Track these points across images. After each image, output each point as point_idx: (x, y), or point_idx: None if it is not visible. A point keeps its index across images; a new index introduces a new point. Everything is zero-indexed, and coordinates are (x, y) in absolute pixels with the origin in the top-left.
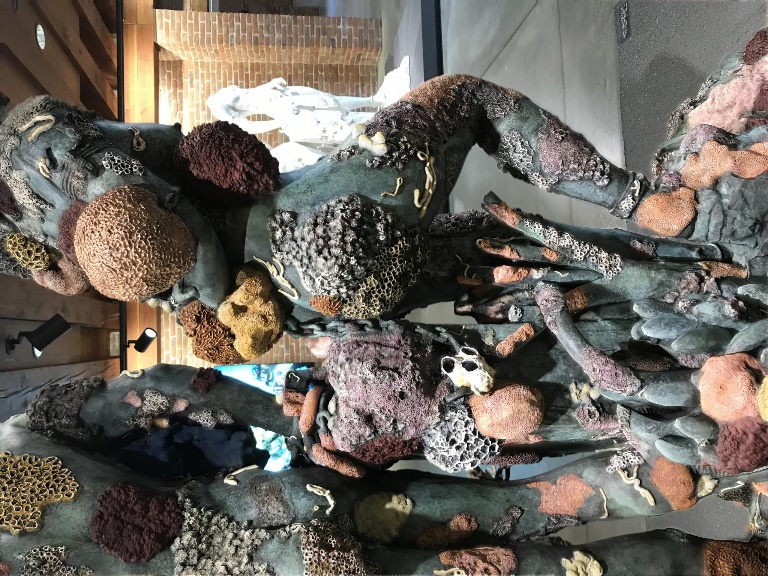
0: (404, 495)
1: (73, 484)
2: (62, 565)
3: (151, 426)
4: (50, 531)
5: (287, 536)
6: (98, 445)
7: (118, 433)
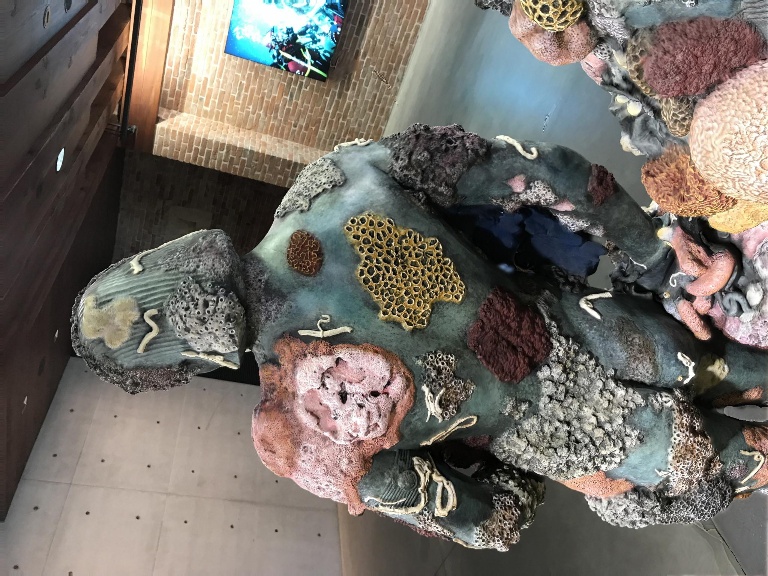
0: (724, 360)
1: (460, 284)
2: (454, 377)
3: (514, 211)
4: (434, 330)
5: (661, 409)
6: (454, 214)
7: (473, 204)
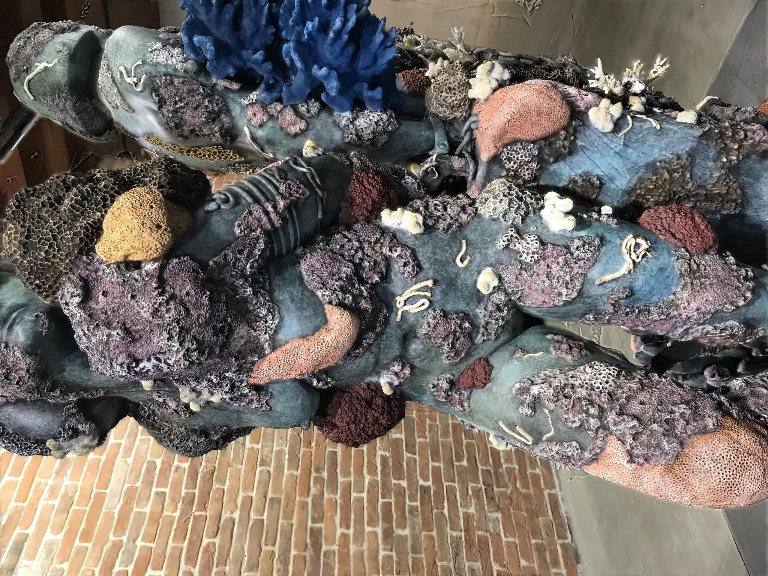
0: None
1: (239, 158)
2: None
3: None
4: None
5: None
6: None
7: None
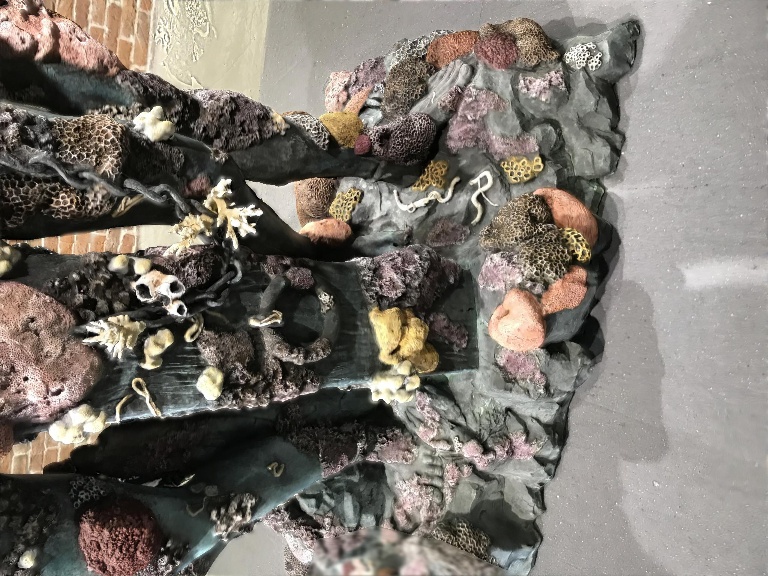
0: None
1: None
2: None
3: None
4: None
5: None
6: None
7: None
